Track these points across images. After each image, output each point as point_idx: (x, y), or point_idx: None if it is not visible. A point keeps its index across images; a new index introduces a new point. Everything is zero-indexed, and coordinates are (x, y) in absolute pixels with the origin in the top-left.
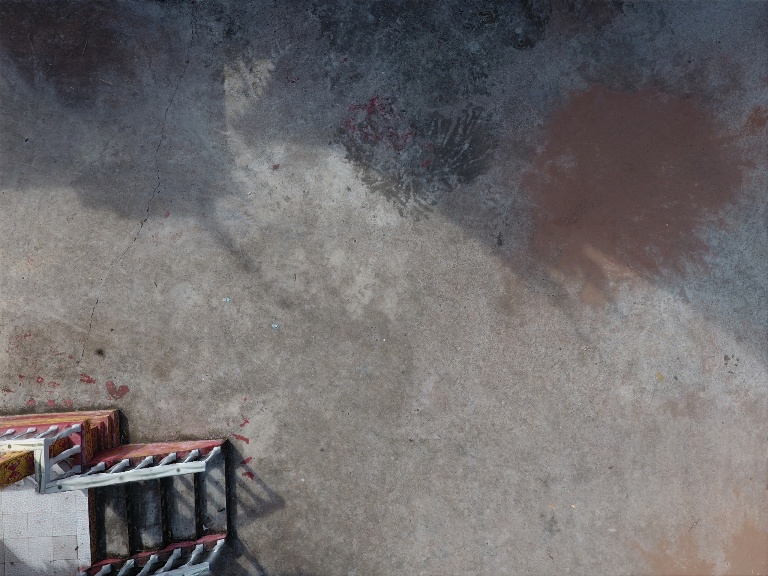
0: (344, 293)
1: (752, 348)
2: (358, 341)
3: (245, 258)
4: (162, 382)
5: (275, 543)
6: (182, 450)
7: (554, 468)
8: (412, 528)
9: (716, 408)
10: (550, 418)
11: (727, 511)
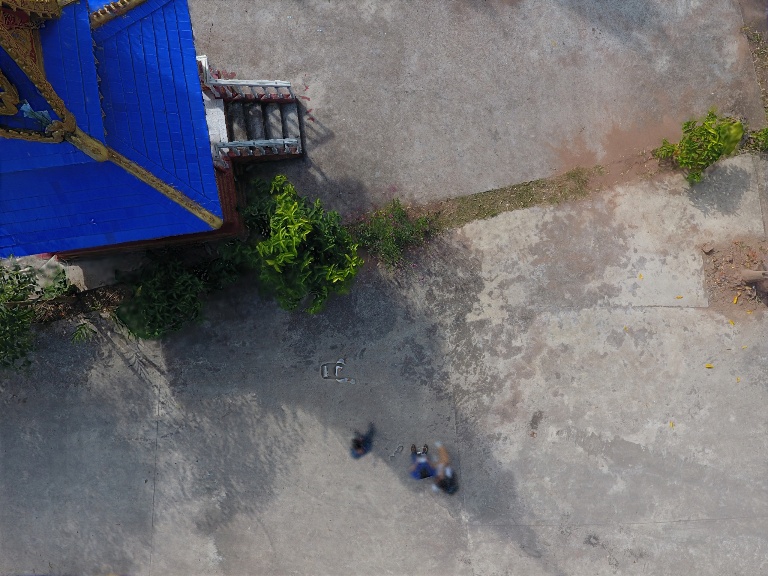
0: (359, 8)
1: (609, 23)
2: (370, 36)
3: None
4: (255, 69)
5: (330, 158)
6: (273, 94)
7: (494, 102)
8: (412, 144)
9: (590, 60)
10: (489, 72)
11: (602, 120)
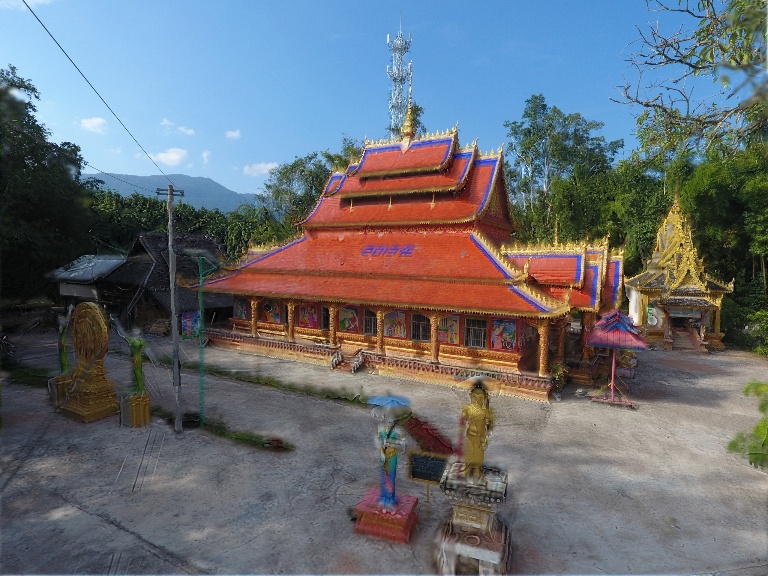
0: None
1: None
2: None
3: (726, 390)
4: None
5: None
6: None
7: None
8: None
9: None
10: None
11: None
